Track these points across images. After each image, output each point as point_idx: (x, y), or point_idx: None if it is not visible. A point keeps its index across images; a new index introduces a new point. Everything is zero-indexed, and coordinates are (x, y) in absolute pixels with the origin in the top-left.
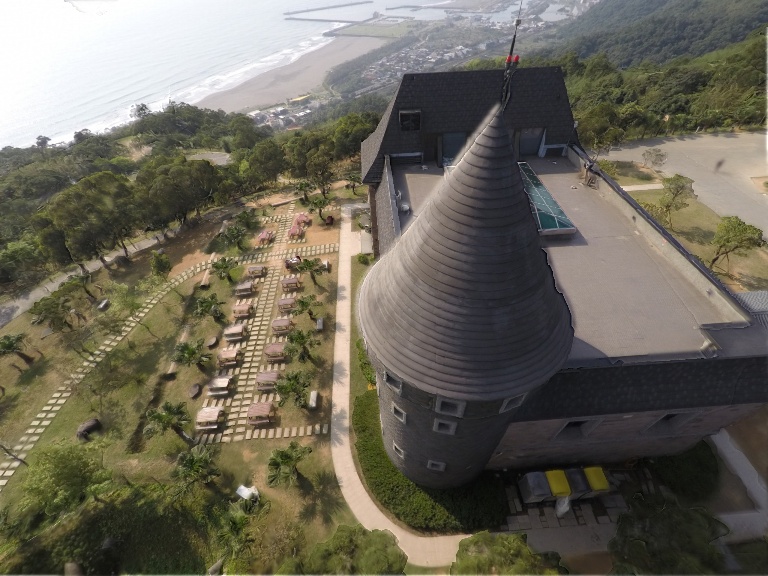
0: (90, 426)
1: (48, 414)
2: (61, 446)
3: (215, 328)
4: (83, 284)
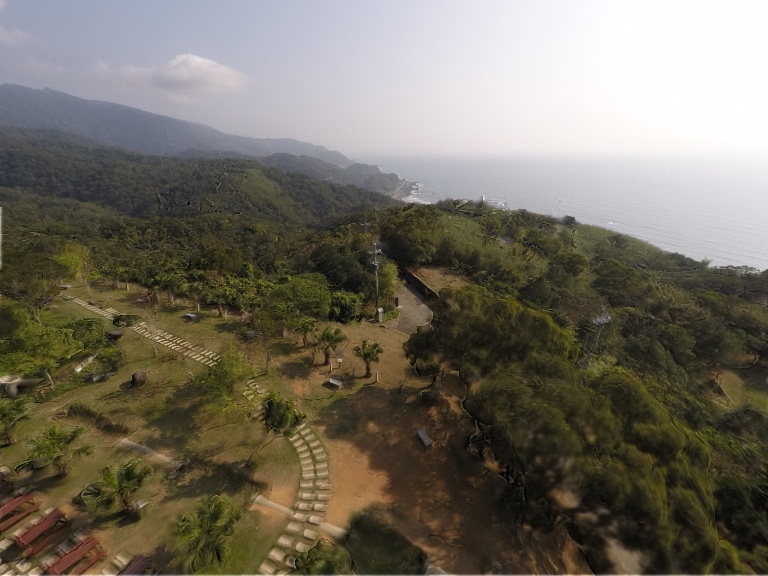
0: (136, 377)
1: (209, 359)
2: (35, 334)
3: (120, 504)
4: (366, 359)
